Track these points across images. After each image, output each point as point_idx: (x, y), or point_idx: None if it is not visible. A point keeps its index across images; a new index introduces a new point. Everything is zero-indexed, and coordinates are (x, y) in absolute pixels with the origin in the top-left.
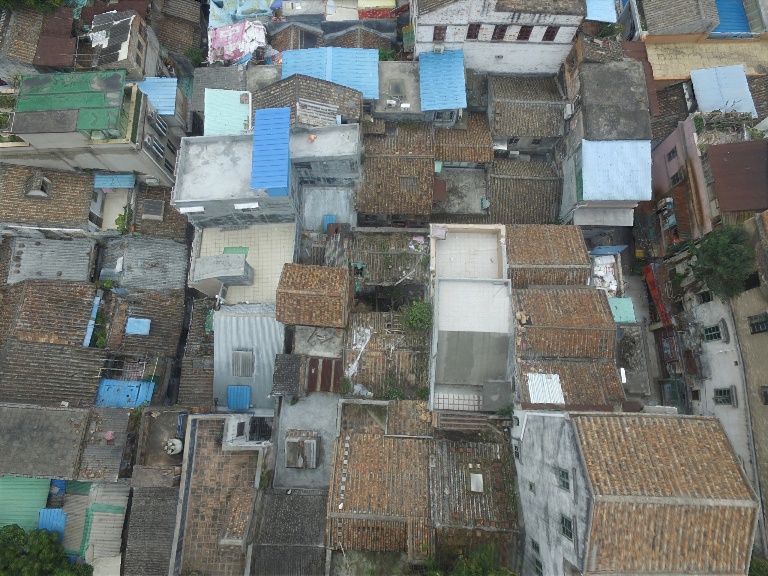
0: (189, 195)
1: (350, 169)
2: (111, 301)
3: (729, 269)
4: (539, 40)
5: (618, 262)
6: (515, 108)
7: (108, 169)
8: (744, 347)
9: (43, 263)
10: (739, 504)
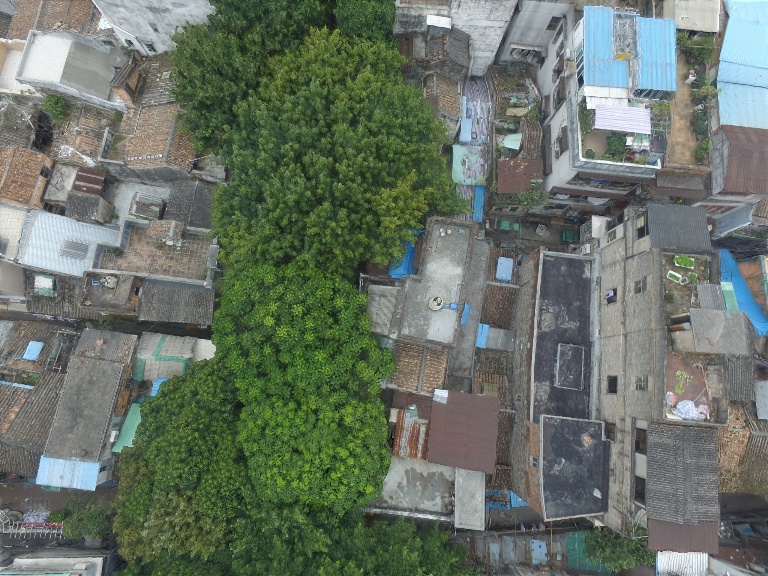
0: None
1: None
2: (4, 377)
3: None
4: None
5: None
6: None
7: None
8: None
9: None
10: None
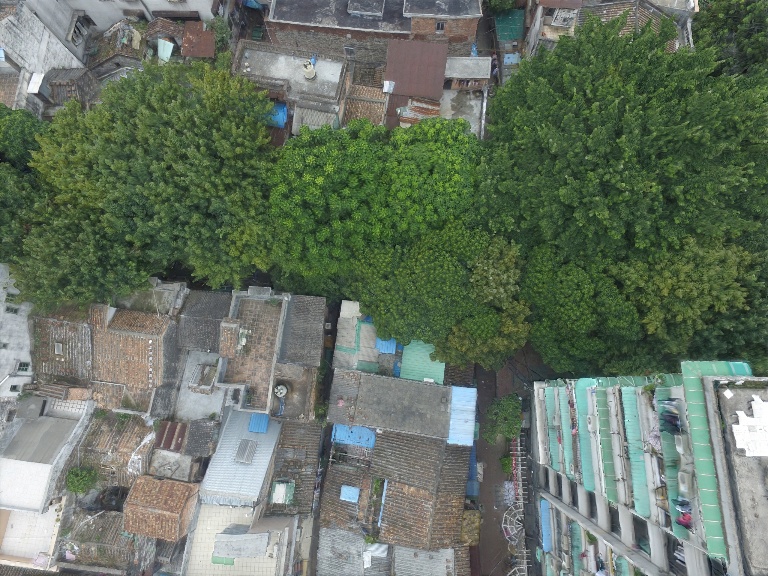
0: None
1: None
2: (377, 522)
3: None
4: None
5: None
6: None
7: None
8: None
9: (430, 568)
10: None
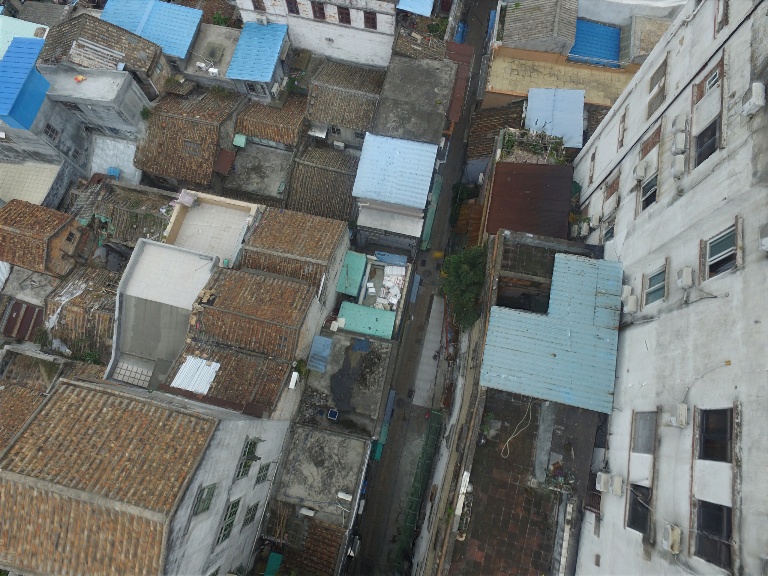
0: None
1: (122, 120)
2: None
3: (456, 291)
4: (362, 26)
5: (407, 275)
6: (333, 94)
7: None
8: (466, 383)
9: None
10: (147, 515)
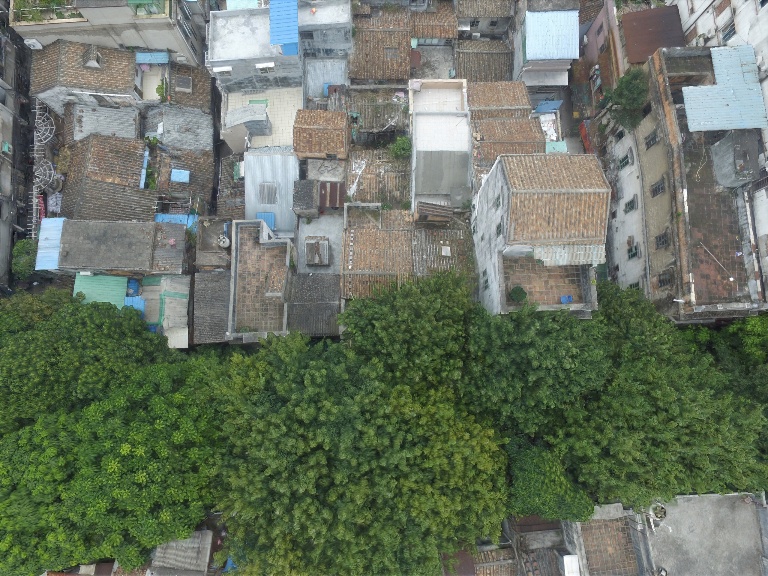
0: (220, 57)
1: (344, 39)
2: (156, 158)
3: (630, 101)
4: None
5: (558, 118)
6: None
7: (147, 47)
8: (642, 162)
9: (100, 126)
10: (599, 191)
